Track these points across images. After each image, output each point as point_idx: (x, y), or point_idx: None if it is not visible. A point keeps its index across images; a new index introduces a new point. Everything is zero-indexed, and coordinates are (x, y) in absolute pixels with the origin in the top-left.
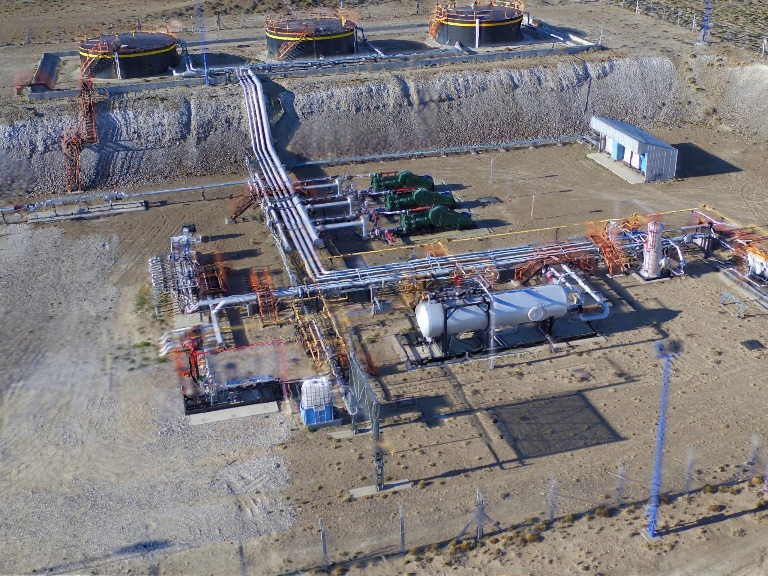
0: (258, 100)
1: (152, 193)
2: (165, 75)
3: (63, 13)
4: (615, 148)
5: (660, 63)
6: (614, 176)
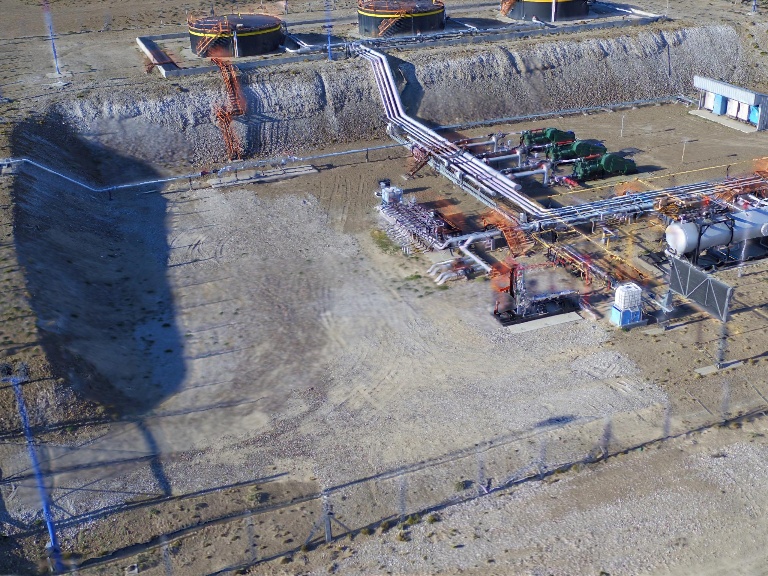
0: (385, 71)
1: (323, 156)
2: (278, 53)
3: (108, 4)
4: (718, 104)
5: (724, 31)
6: (726, 127)
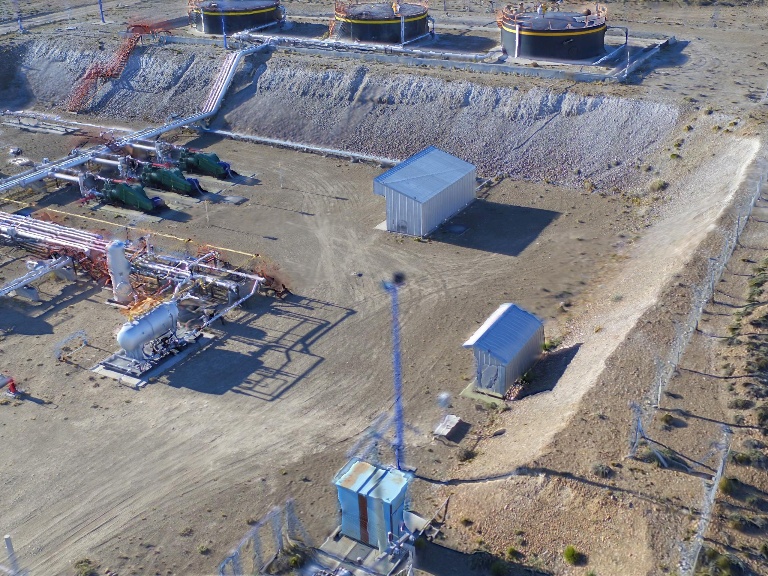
0: (231, 67)
1: (71, 122)
2: None
3: None
4: None
5: (662, 112)
6: None
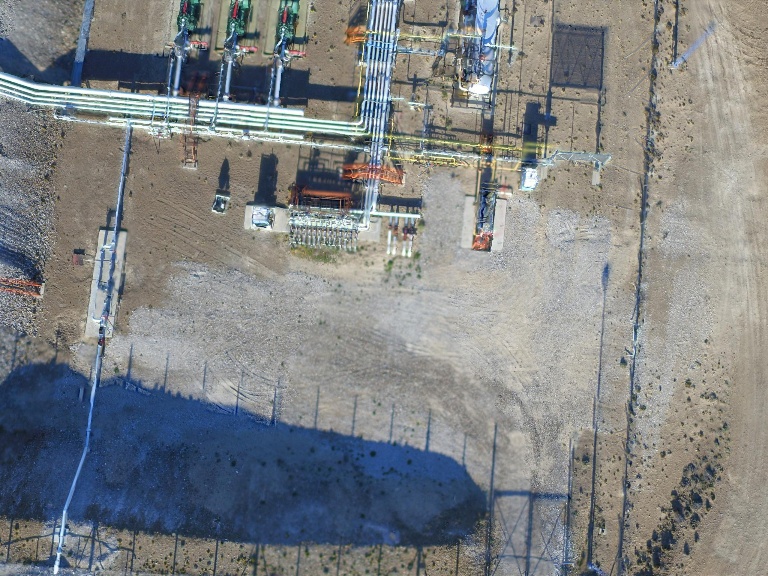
0: None
1: None
2: None
3: None
4: None
5: None
6: None
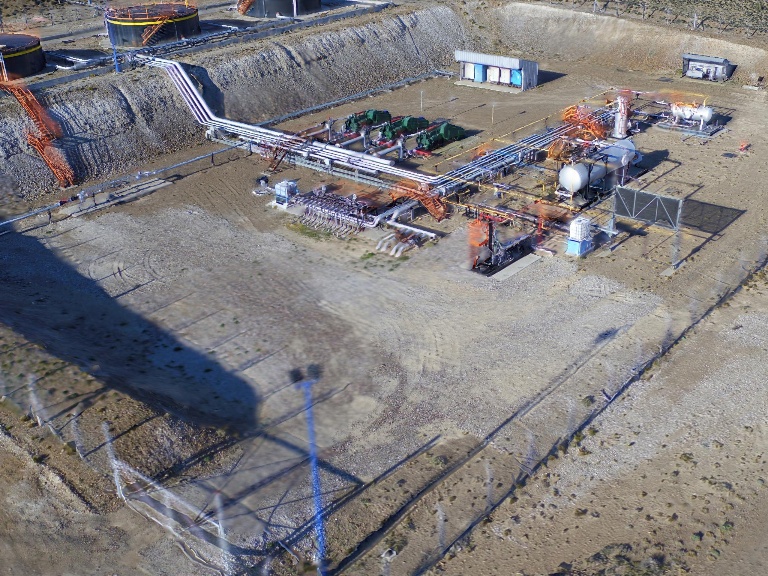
0: (183, 77)
1: (174, 167)
2: (48, 72)
3: None
4: (479, 73)
5: (444, 11)
6: (496, 92)
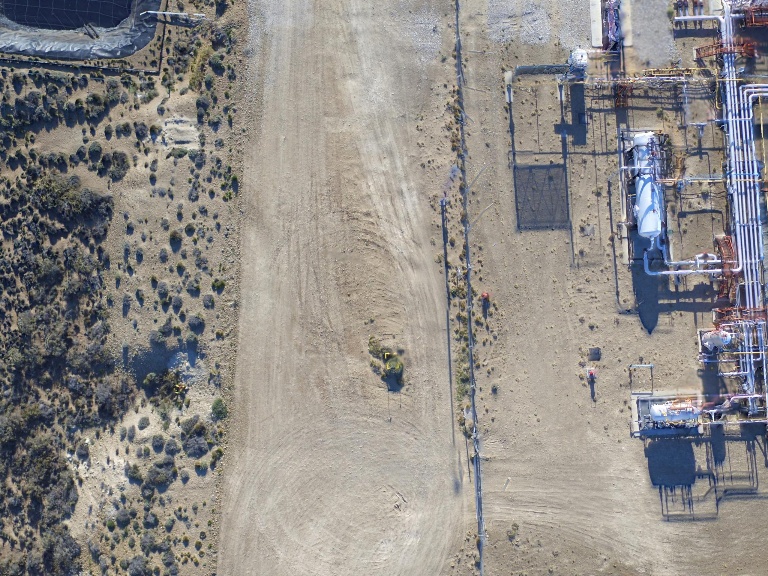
0: None
1: None
2: None
3: None
4: None
5: None
6: None
